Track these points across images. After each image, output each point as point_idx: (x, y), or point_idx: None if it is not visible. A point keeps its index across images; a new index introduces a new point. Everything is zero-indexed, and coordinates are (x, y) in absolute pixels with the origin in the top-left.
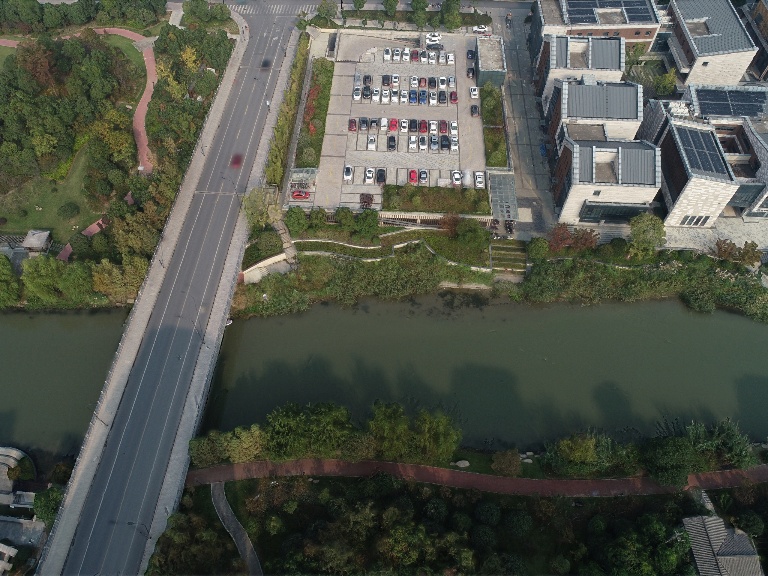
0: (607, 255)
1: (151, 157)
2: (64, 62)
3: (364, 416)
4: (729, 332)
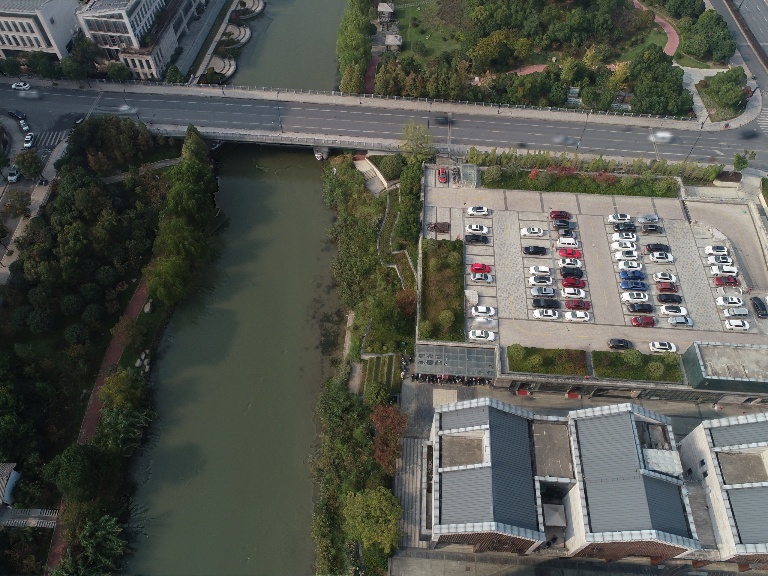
0: (368, 484)
1: (461, 64)
2: (594, 8)
3: (216, 247)
4: None
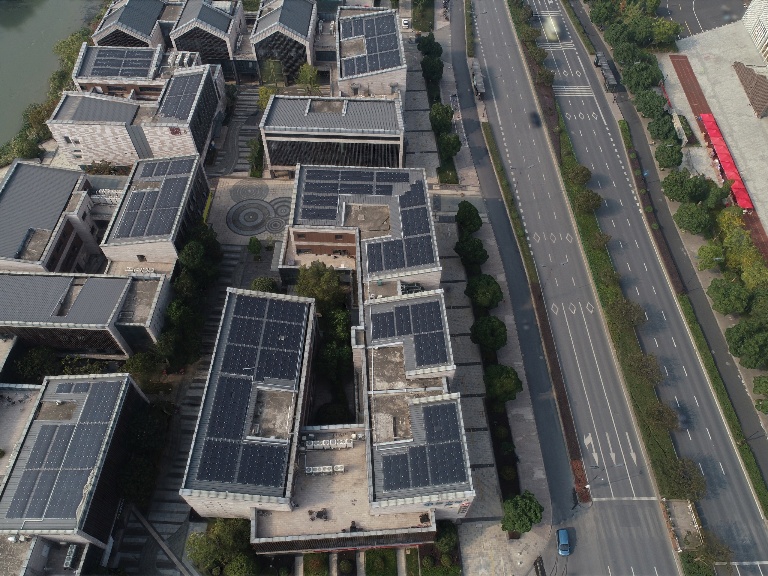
0: None
1: None
2: None
3: None
4: (3, 127)
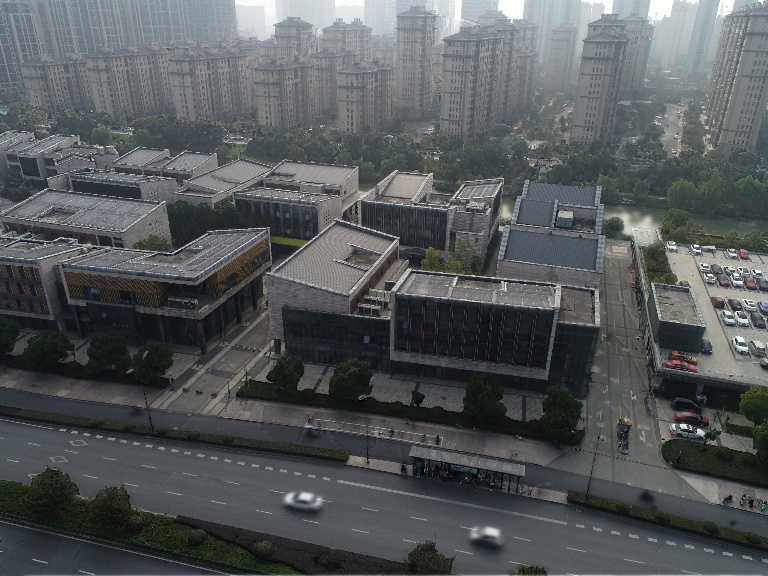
0: None
1: None
2: None
3: None
4: None
